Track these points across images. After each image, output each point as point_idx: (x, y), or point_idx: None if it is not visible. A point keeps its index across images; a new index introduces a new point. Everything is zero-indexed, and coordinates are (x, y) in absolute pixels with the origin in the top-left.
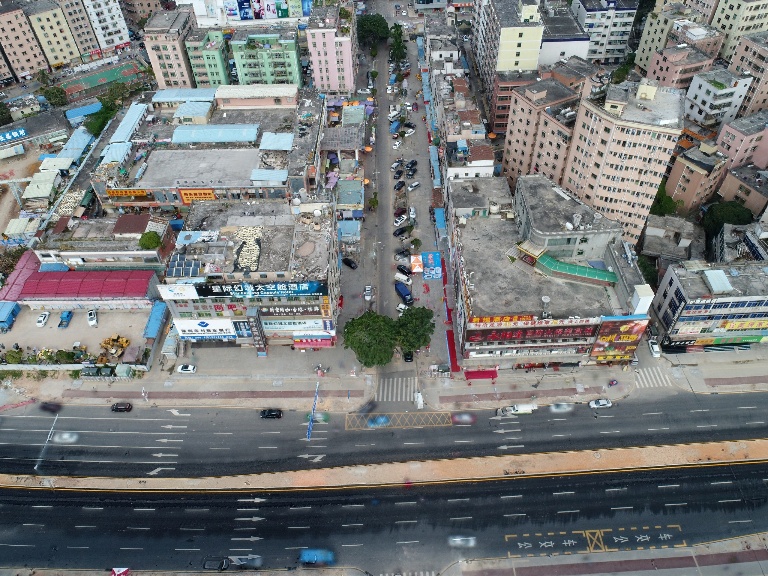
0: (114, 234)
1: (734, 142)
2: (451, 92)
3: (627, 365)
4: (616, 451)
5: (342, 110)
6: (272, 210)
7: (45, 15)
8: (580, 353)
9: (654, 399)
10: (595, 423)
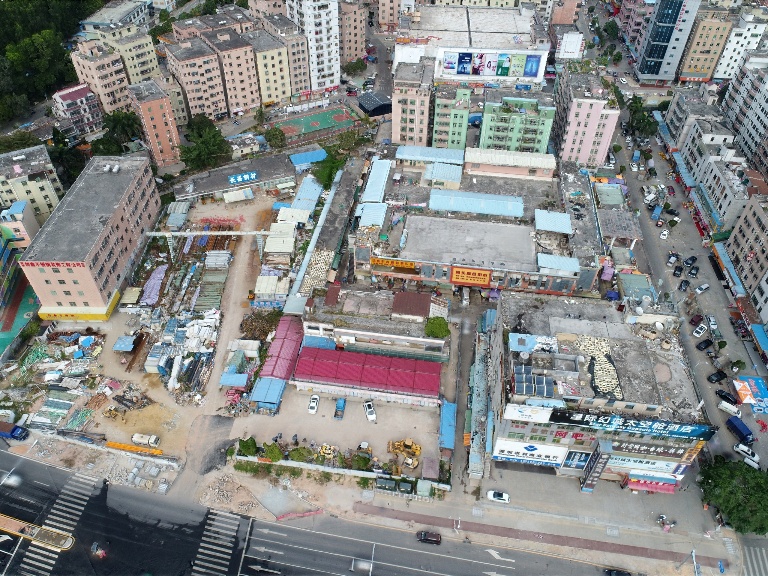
0: (392, 313)
1: None
2: (742, 184)
3: None
4: None
5: (595, 187)
6: (599, 314)
7: (271, 53)
8: None
9: None
10: None
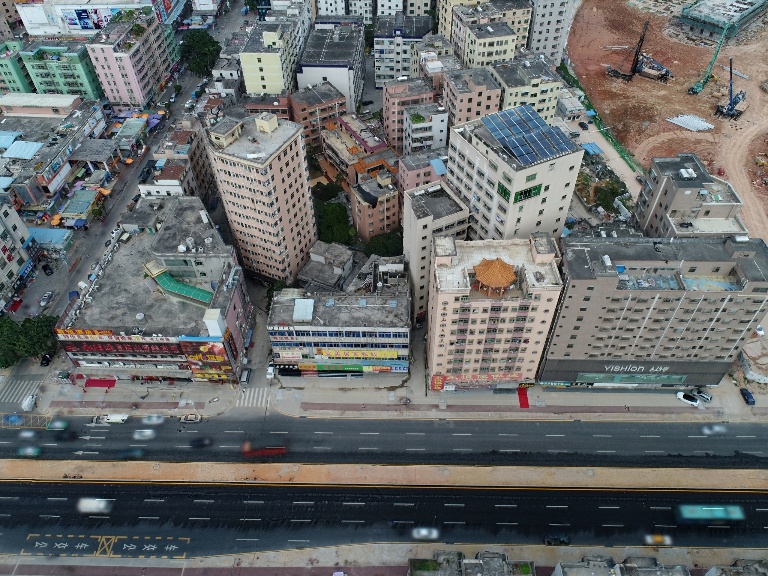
0: None
1: (405, 176)
2: None
3: (238, 384)
4: (176, 464)
5: (124, 122)
6: None
7: None
8: (184, 369)
9: (244, 418)
10: (176, 437)
